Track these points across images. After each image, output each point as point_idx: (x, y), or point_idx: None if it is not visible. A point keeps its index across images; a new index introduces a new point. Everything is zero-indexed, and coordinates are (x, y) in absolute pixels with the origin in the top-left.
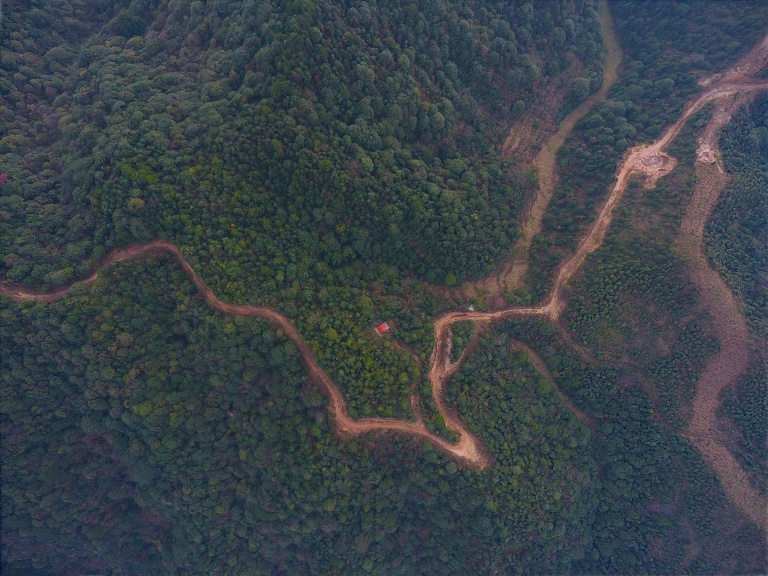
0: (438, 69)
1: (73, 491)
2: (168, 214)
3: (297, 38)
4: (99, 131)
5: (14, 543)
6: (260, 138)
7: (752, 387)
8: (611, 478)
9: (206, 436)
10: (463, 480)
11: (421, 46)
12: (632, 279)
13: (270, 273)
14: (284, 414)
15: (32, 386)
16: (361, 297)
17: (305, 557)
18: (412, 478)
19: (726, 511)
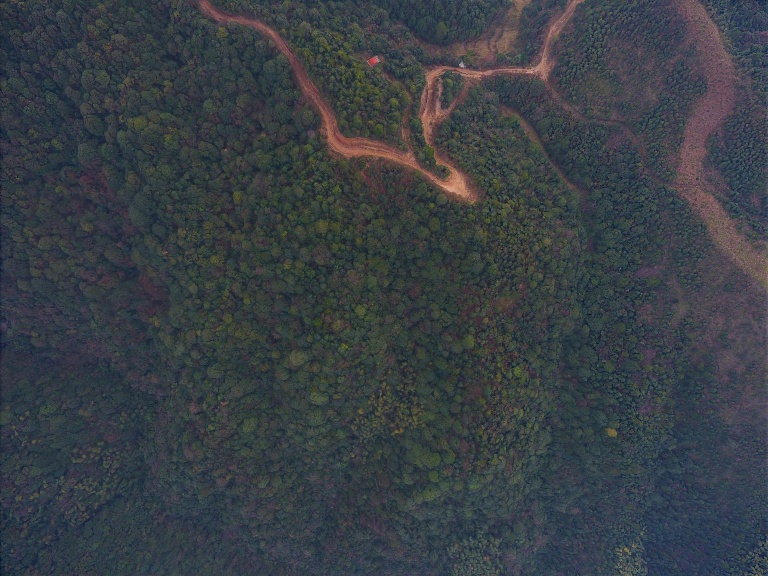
0: None
1: (70, 241)
2: None
3: None
4: None
5: (13, 306)
6: None
7: (738, 128)
8: (601, 249)
9: (200, 171)
10: (453, 214)
11: None
12: (620, 18)
13: None
14: (277, 142)
15: (29, 100)
16: None
17: (299, 310)
18: (403, 217)
19: (713, 259)
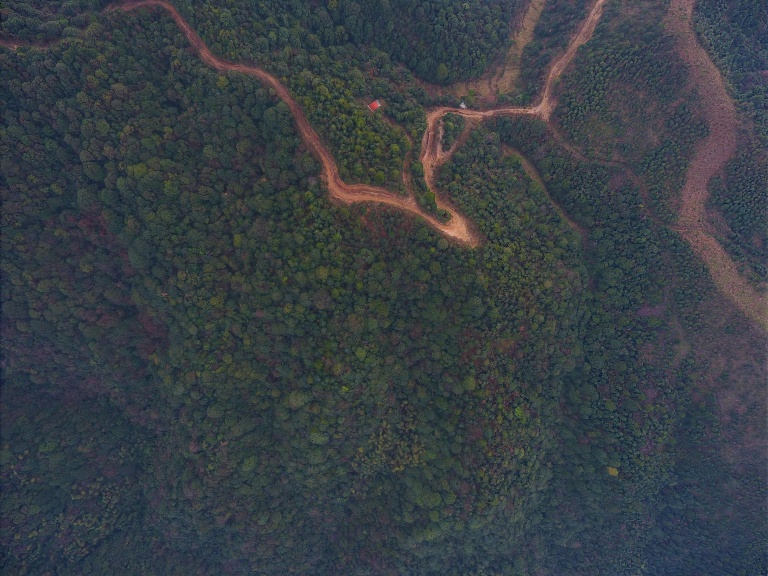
0: None
1: (70, 282)
2: None
3: None
4: None
5: (12, 346)
6: None
7: (740, 171)
8: (602, 287)
9: (200, 215)
10: (454, 258)
11: None
12: (621, 62)
13: (262, 31)
14: (277, 188)
15: (28, 147)
16: None
17: (299, 351)
18: (404, 260)
19: (715, 301)
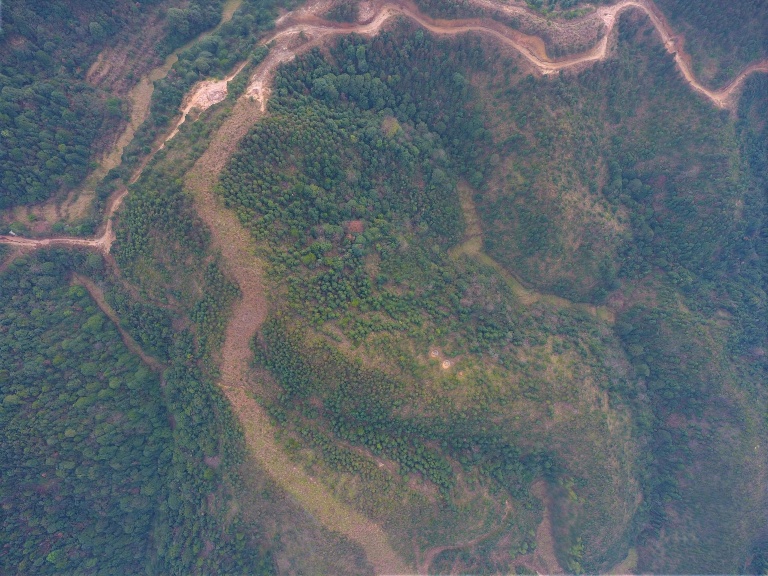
0: None
1: None
2: None
3: None
4: None
5: None
6: None
7: (271, 337)
8: (177, 427)
9: None
10: None
11: None
12: (150, 211)
13: None
14: None
15: None
16: None
17: None
18: None
19: (250, 465)
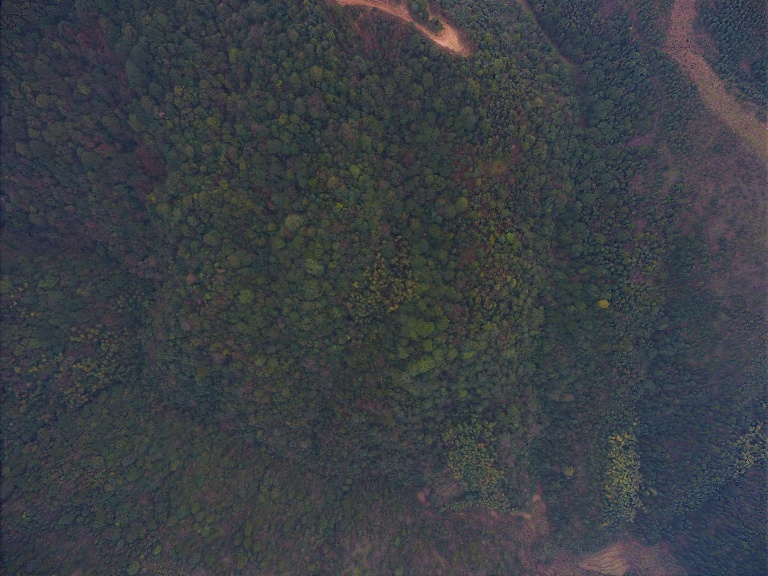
0: None
1: (68, 102)
2: None
3: None
4: None
5: (11, 175)
6: None
7: None
8: (593, 122)
9: (196, 24)
10: (446, 67)
11: None
12: None
13: None
14: None
15: None
16: None
17: (294, 173)
18: (397, 73)
19: (703, 120)
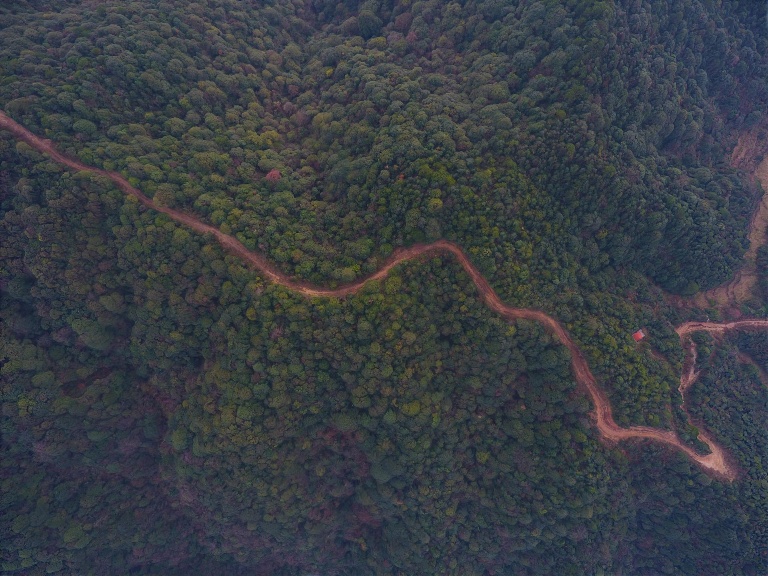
0: (690, 77)
1: (305, 487)
2: (465, 215)
3: (599, 43)
4: (373, 130)
5: (231, 536)
6: (554, 142)
7: None
8: None
9: (454, 437)
10: (712, 492)
11: (678, 54)
12: None
13: (550, 277)
14: (539, 418)
15: (303, 381)
16: (622, 304)
17: (530, 563)
18: (656, 488)
19: None
